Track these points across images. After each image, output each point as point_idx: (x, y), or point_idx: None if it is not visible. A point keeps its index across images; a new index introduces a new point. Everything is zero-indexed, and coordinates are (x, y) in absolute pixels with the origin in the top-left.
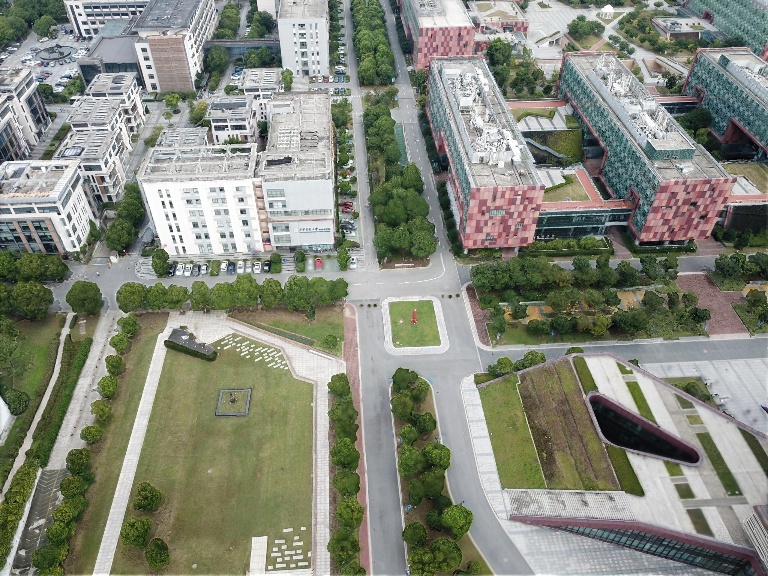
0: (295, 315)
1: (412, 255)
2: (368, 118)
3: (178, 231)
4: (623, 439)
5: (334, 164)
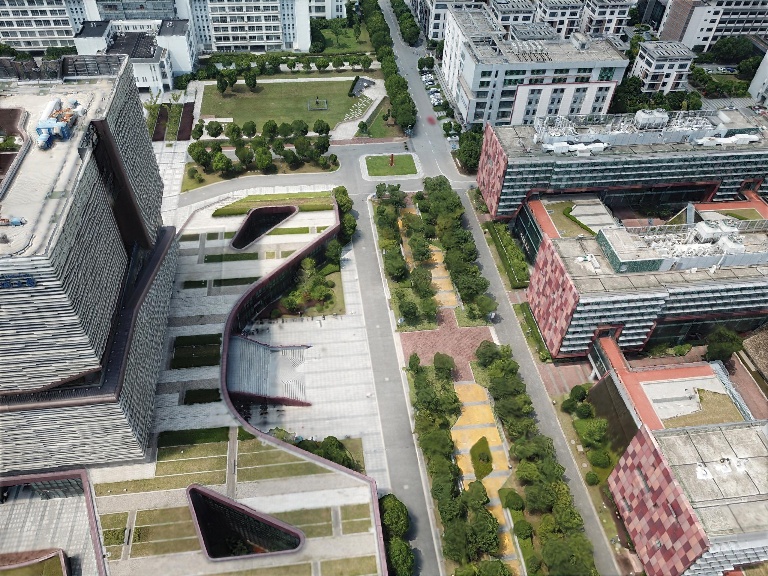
0: (392, 119)
1: None
2: None
3: None
4: None
5: None
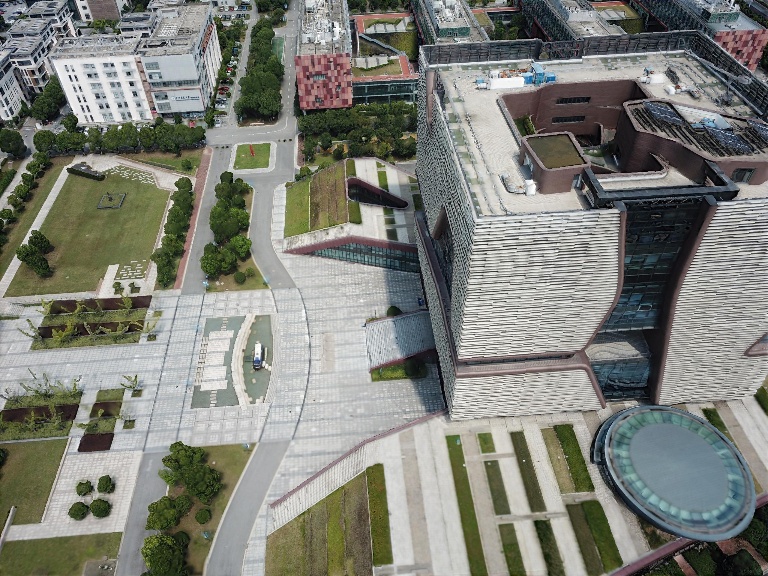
0: (167, 154)
1: (264, 118)
2: (253, 31)
3: (85, 102)
4: None
5: (221, 63)
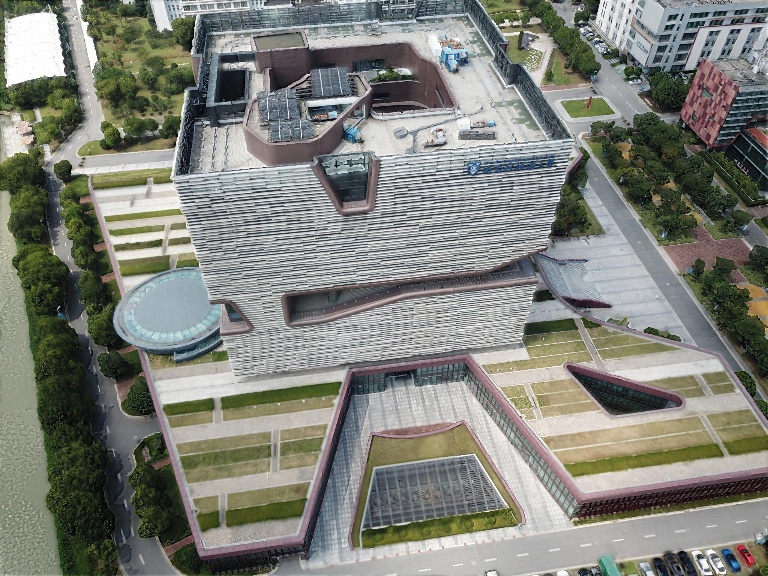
0: (569, 68)
1: None
2: None
3: None
4: None
5: None
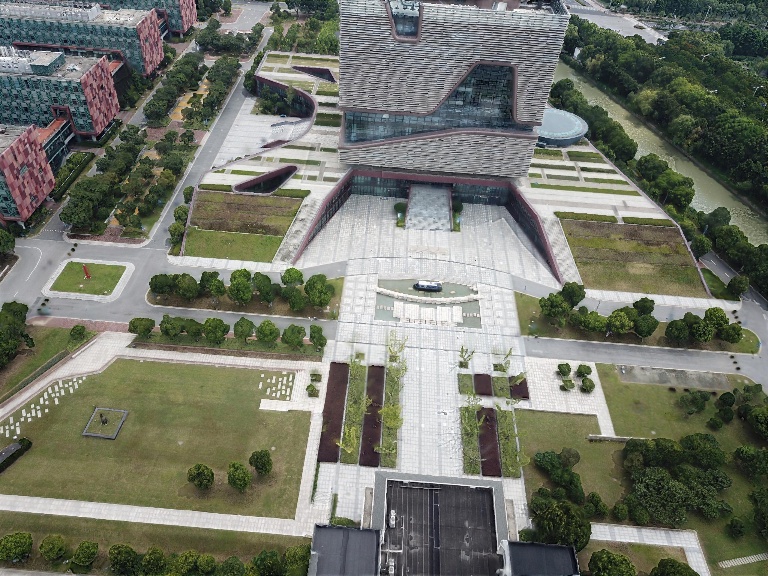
0: (11, 365)
1: None
2: None
3: None
4: None
5: None
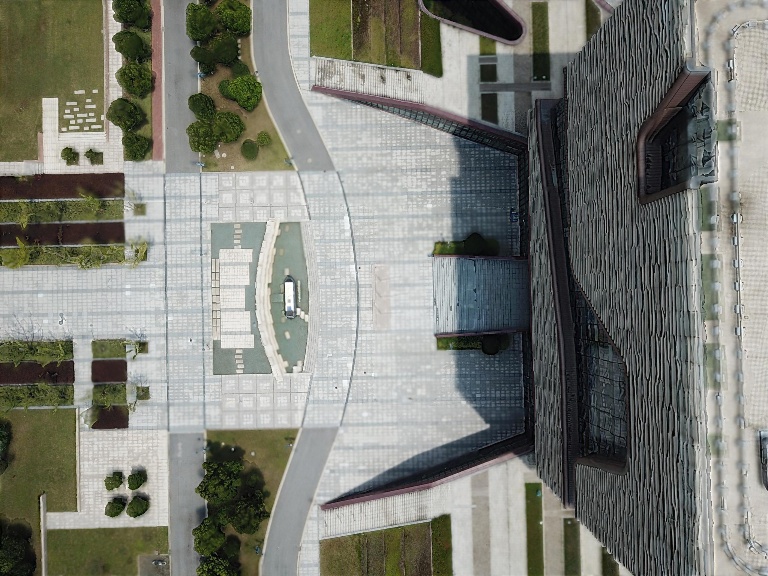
0: None
1: None
2: None
3: None
4: (462, 1)
5: None
